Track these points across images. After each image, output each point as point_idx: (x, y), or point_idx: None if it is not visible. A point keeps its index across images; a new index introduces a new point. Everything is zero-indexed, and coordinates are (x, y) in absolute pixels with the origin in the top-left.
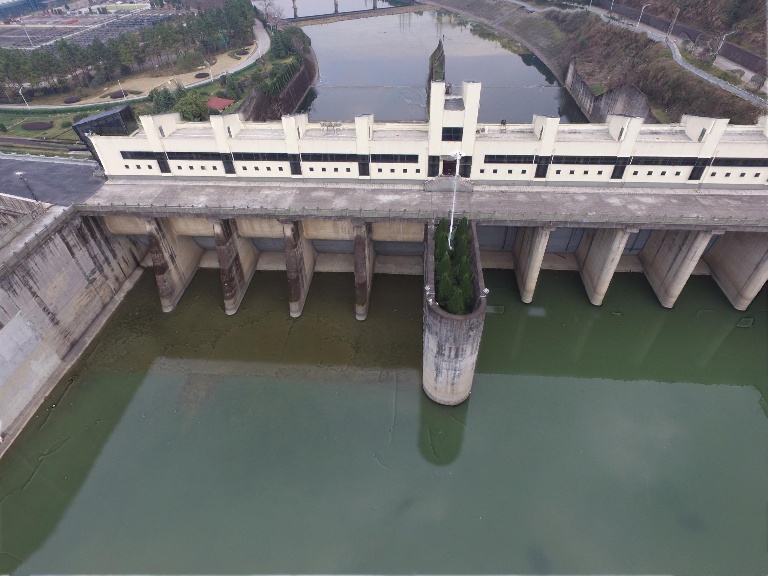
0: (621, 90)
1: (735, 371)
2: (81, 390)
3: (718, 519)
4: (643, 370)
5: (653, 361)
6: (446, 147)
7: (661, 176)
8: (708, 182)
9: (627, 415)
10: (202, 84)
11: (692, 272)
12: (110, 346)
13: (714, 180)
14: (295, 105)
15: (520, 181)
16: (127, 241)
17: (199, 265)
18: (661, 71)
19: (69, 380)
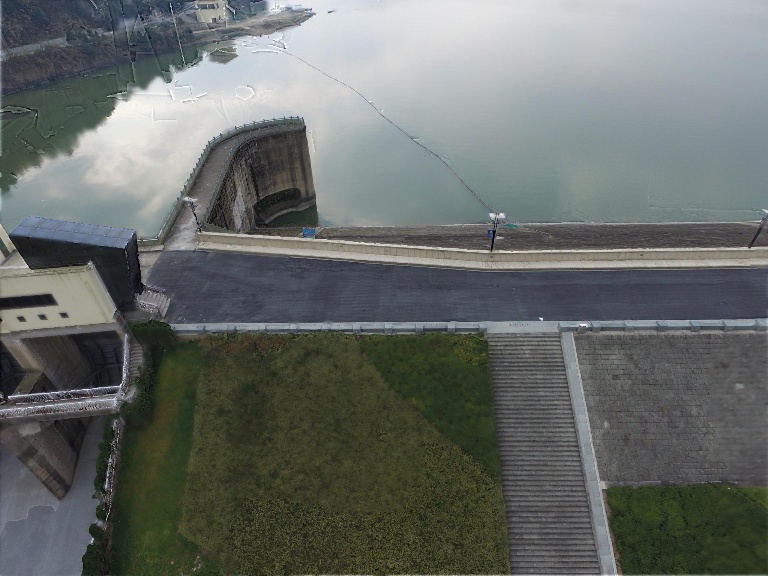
0: None
1: None
2: None
3: None
4: None
5: None
6: None
7: None
8: None
9: None
10: None
11: None
12: None
13: None
14: None
15: None
16: None
17: None
18: None
19: None
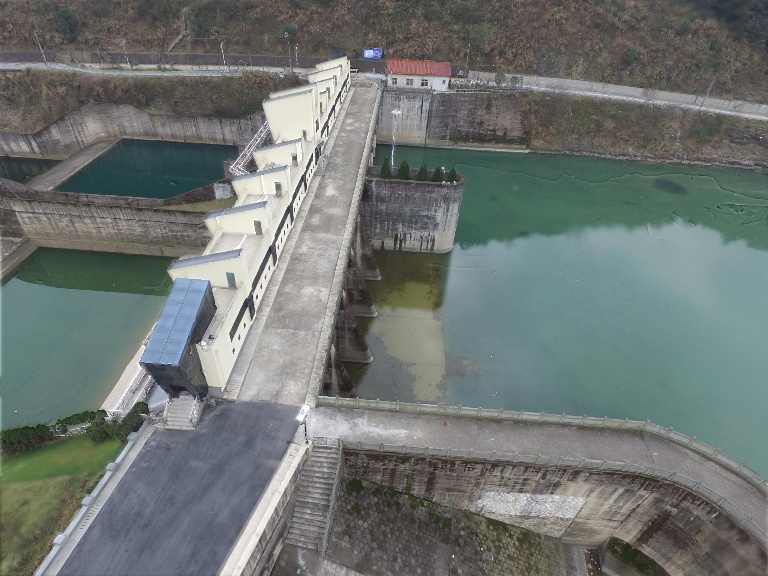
0: (83, 112)
1: None
2: None
3: None
4: None
5: None
6: (318, 138)
7: None
8: None
9: None
10: None
11: None
12: None
13: None
14: None
15: (325, 143)
16: None
17: None
18: (109, 83)
19: None
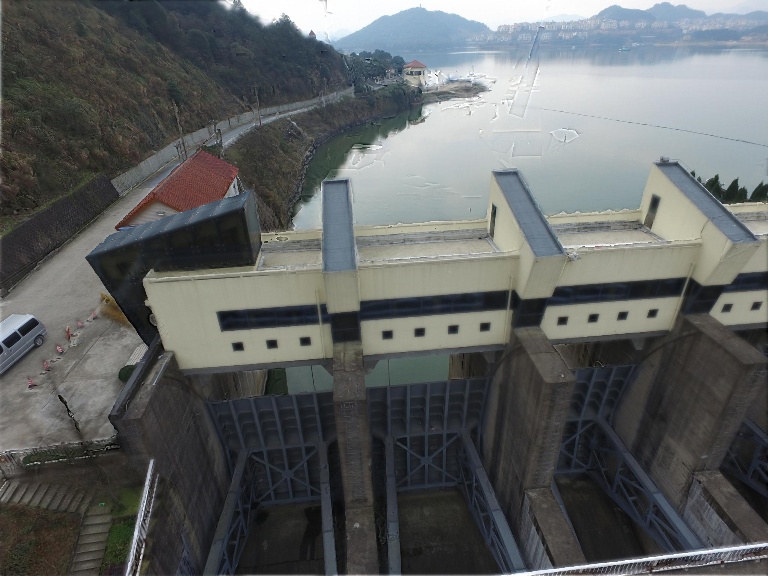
0: None
1: None
2: None
3: None
4: None
5: None
6: None
7: None
8: None
9: None
10: None
11: None
12: None
13: None
14: None
15: None
16: None
17: None
18: None
19: None
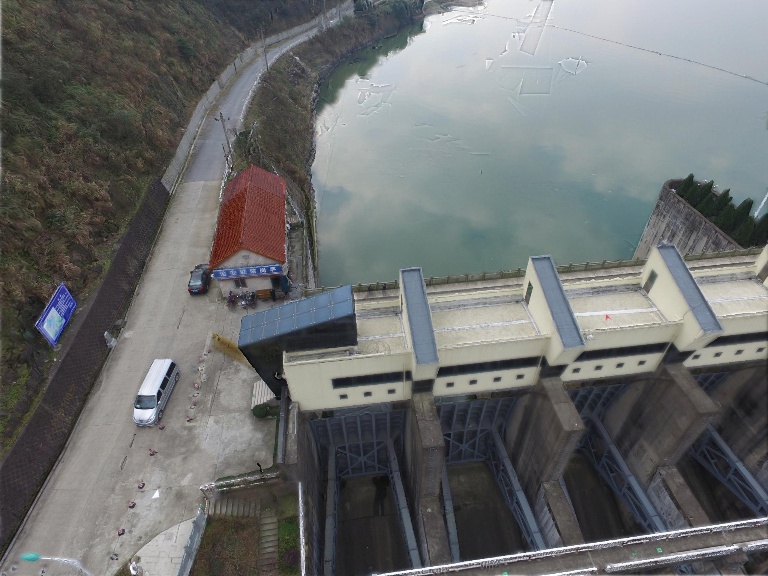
0: None
1: None
2: None
3: None
4: None
5: None
6: None
7: None
8: None
9: None
10: None
11: None
12: None
13: None
14: None
15: None
16: None
17: None
18: None
19: None
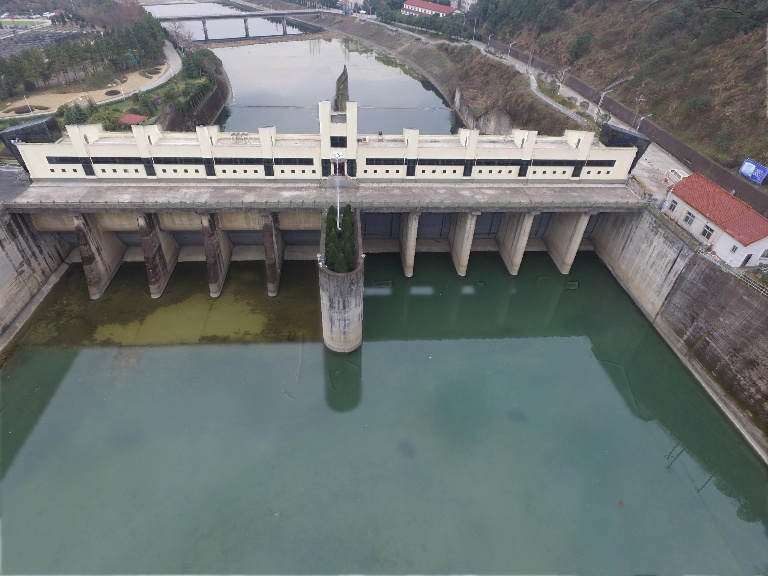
0: (493, 112)
1: (571, 324)
2: (16, 366)
3: (533, 409)
4: (505, 329)
5: (512, 321)
6: None
7: (499, 174)
8: (532, 178)
9: (478, 350)
10: (113, 101)
11: (534, 249)
12: (41, 329)
13: (536, 176)
14: (209, 122)
15: (396, 179)
16: (52, 239)
17: (123, 260)
18: (520, 97)
19: (3, 359)
